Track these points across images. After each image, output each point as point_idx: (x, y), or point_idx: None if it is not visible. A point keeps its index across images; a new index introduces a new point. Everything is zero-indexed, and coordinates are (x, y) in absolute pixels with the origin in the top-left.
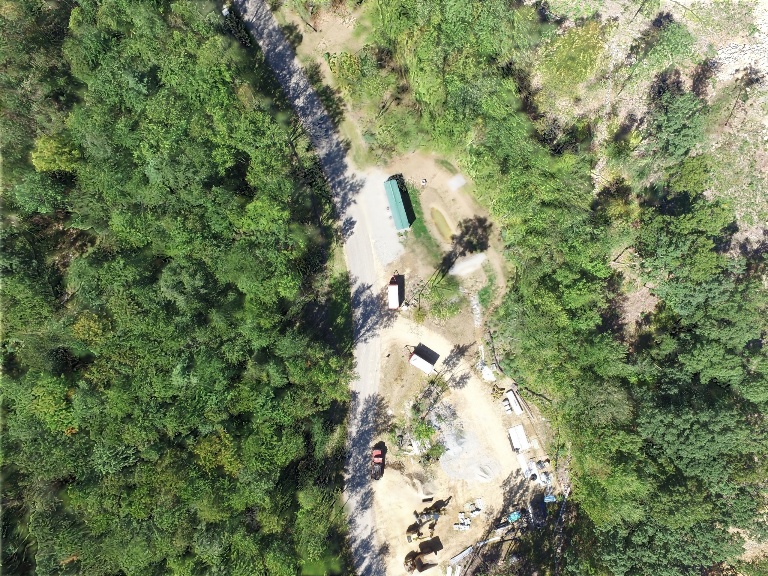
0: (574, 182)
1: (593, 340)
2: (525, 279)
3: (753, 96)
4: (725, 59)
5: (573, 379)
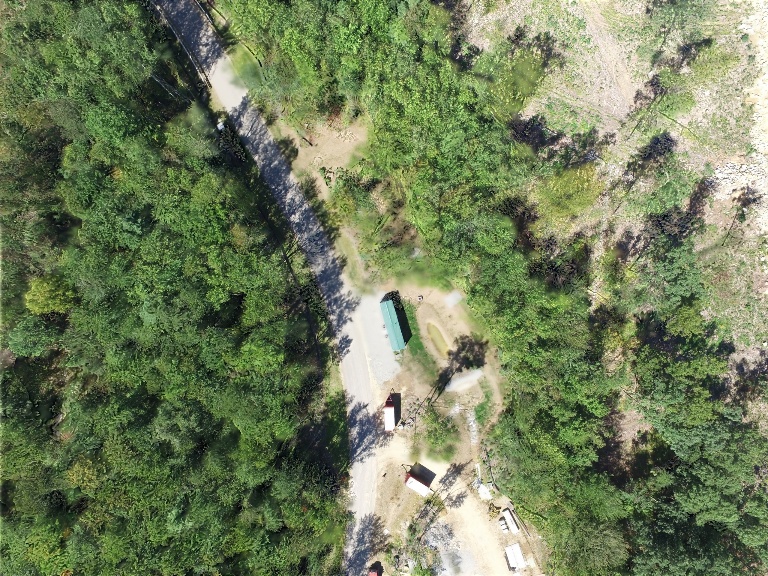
0: (571, 303)
1: (589, 479)
2: (521, 413)
3: (750, 216)
4: (722, 180)
5: (569, 518)
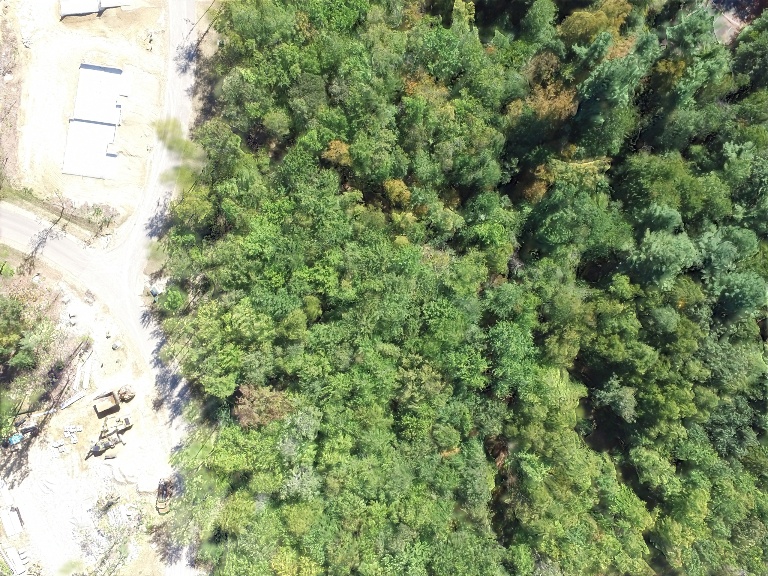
0: None
1: None
2: None
3: None
4: None
5: None
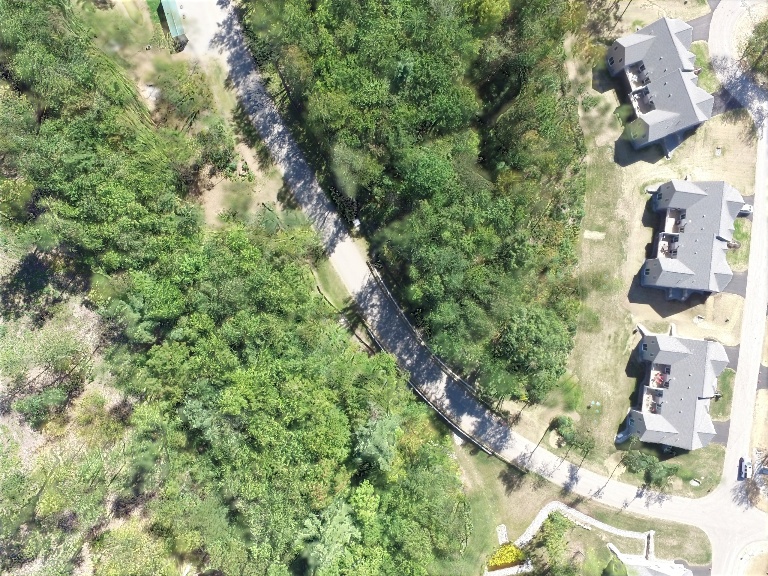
0: None
1: None
2: None
3: None
4: None
5: None
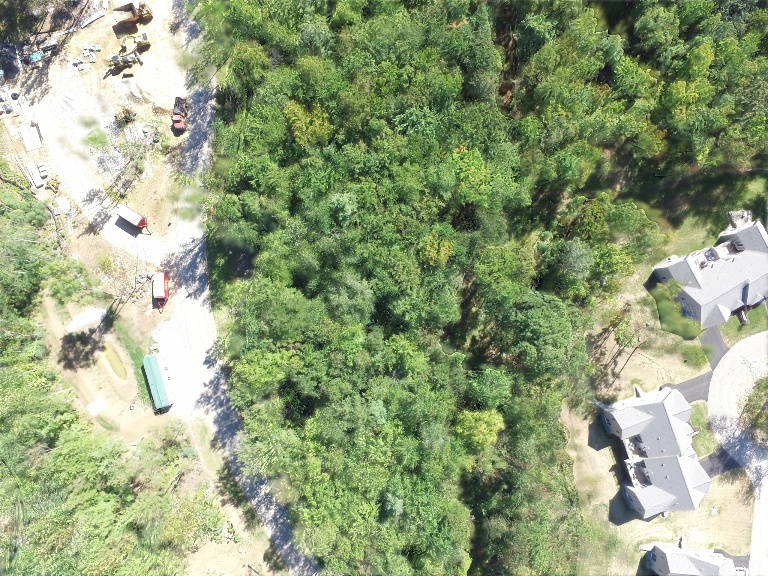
0: None
1: None
2: None
3: None
4: None
5: None
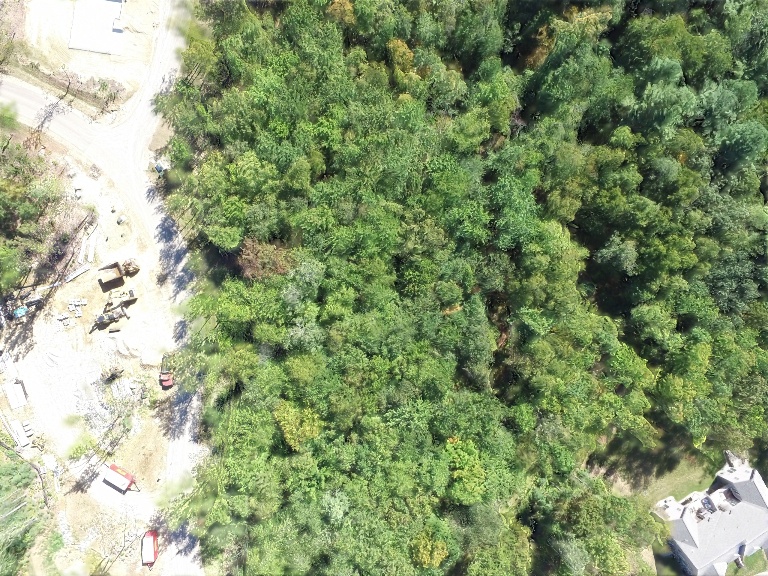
0: None
1: None
2: None
3: None
4: None
5: None
